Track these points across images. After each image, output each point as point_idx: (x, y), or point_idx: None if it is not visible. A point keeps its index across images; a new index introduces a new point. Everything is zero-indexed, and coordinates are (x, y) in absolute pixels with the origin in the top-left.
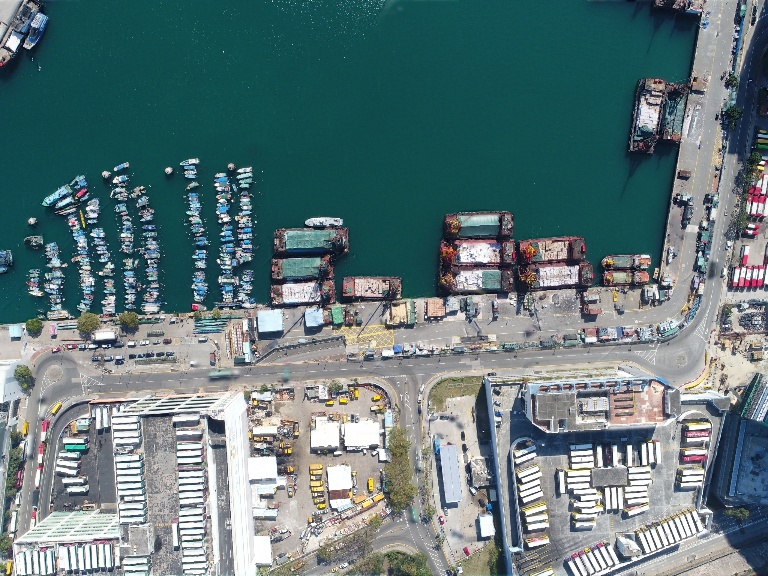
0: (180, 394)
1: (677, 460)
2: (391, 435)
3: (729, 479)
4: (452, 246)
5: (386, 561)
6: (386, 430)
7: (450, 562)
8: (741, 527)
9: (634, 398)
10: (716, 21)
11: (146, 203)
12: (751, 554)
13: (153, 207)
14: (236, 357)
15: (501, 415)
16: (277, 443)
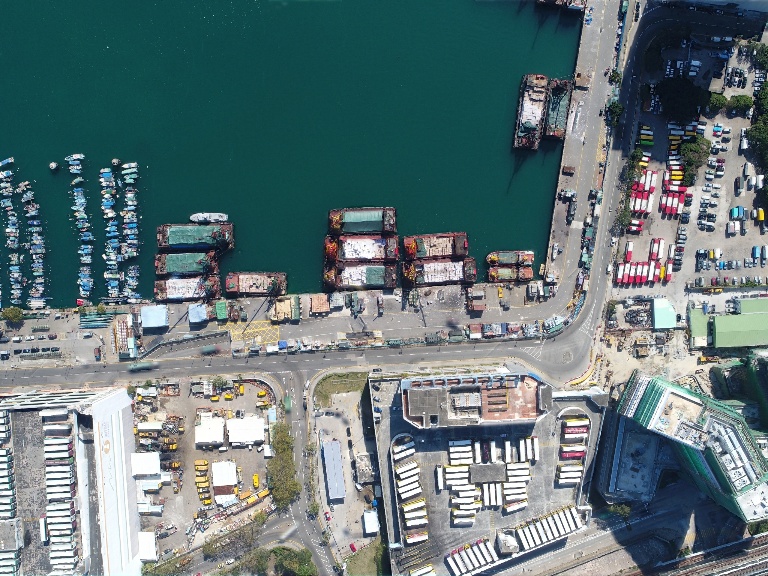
0: (65, 389)
1: (557, 456)
2: (275, 431)
3: (609, 475)
4: (337, 242)
5: (272, 557)
6: (270, 426)
7: (336, 558)
8: (628, 524)
9: (507, 394)
10: (599, 17)
11: (31, 198)
12: (637, 551)
13: (38, 202)
14: (121, 352)
15: (380, 411)
16: (163, 439)
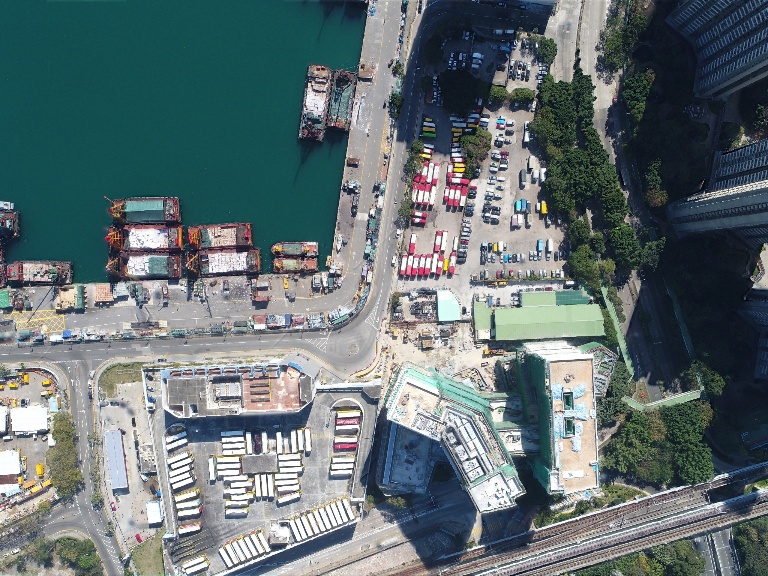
0: None
1: (331, 448)
2: None
3: (383, 467)
4: (121, 231)
5: None
6: (51, 415)
7: (122, 549)
8: (415, 517)
9: (270, 384)
10: (383, 9)
11: None
12: (422, 544)
13: None
14: None
15: (153, 401)
16: None
